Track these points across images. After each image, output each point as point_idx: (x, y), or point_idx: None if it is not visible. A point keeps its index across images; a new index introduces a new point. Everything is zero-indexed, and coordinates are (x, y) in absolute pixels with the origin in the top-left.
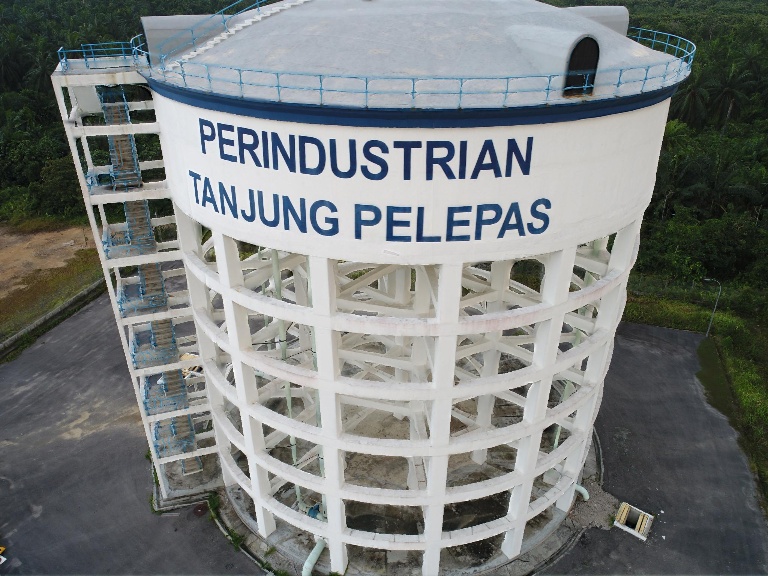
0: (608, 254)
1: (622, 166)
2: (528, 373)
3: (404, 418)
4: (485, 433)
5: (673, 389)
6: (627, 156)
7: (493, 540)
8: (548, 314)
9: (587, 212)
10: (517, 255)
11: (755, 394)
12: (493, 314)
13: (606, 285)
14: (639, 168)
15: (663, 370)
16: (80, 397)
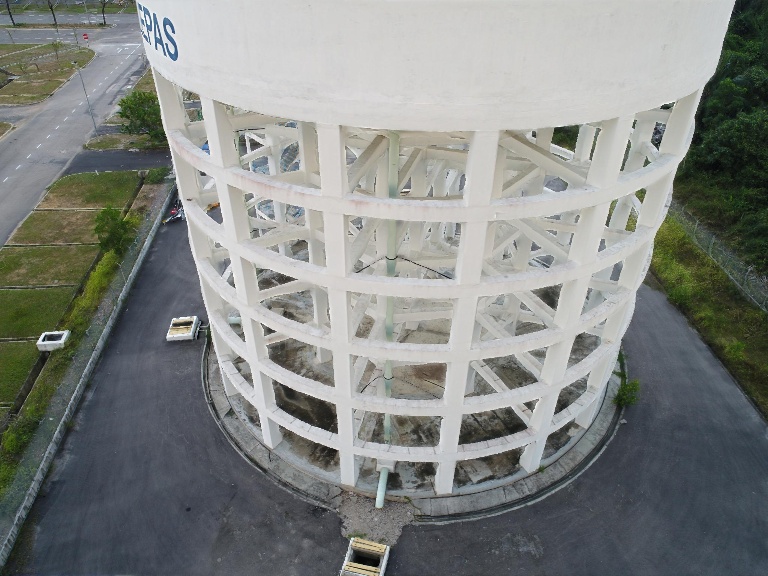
0: (563, 268)
1: (243, 16)
2: (217, 231)
3: (409, 329)
4: (217, 275)
5: None
6: (249, 4)
7: (283, 427)
8: (210, 170)
9: (209, 59)
10: (169, 77)
11: None
12: (187, 141)
13: (278, 188)
14: (289, 36)
15: None
16: None
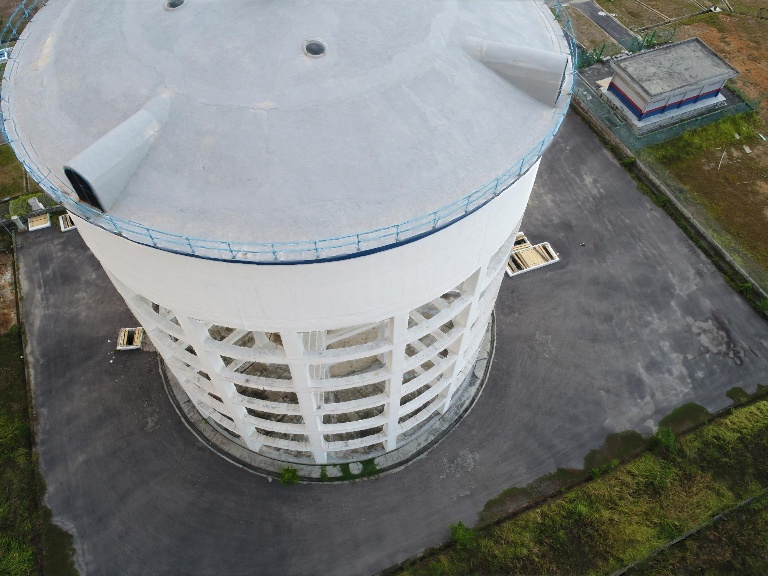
0: None
1: None
2: None
3: None
4: None
5: (110, 534)
6: None
7: None
8: None
9: None
10: None
11: (15, 572)
12: None
13: None
14: None
15: (124, 568)
16: (547, 197)
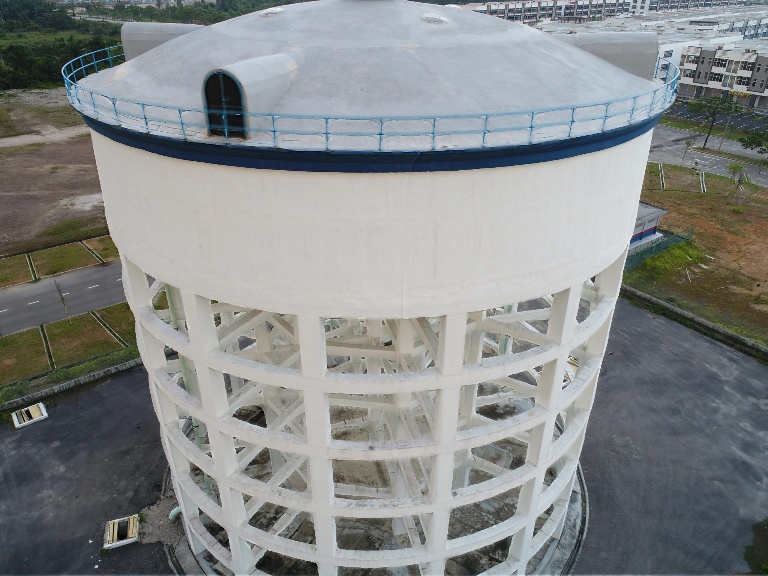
0: (196, 404)
1: None
2: None
3: None
4: None
5: None
6: None
7: None
8: None
9: None
10: None
11: None
12: None
13: None
14: None
15: None
16: None
